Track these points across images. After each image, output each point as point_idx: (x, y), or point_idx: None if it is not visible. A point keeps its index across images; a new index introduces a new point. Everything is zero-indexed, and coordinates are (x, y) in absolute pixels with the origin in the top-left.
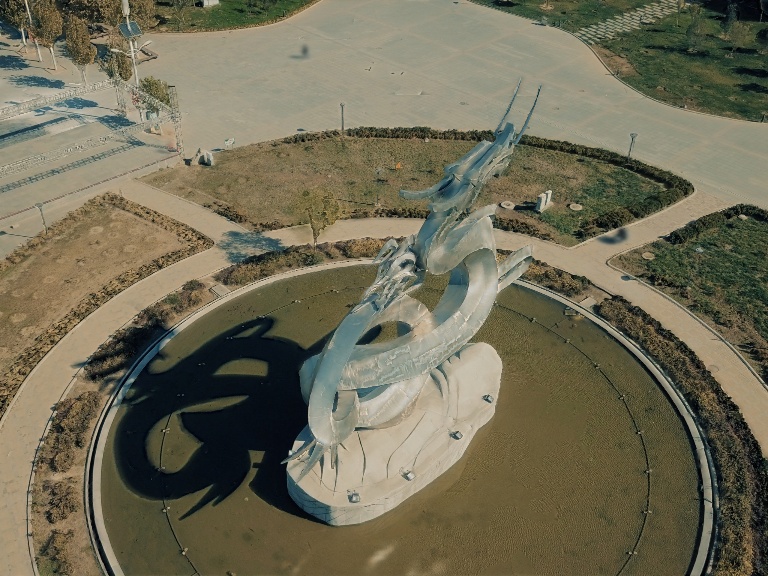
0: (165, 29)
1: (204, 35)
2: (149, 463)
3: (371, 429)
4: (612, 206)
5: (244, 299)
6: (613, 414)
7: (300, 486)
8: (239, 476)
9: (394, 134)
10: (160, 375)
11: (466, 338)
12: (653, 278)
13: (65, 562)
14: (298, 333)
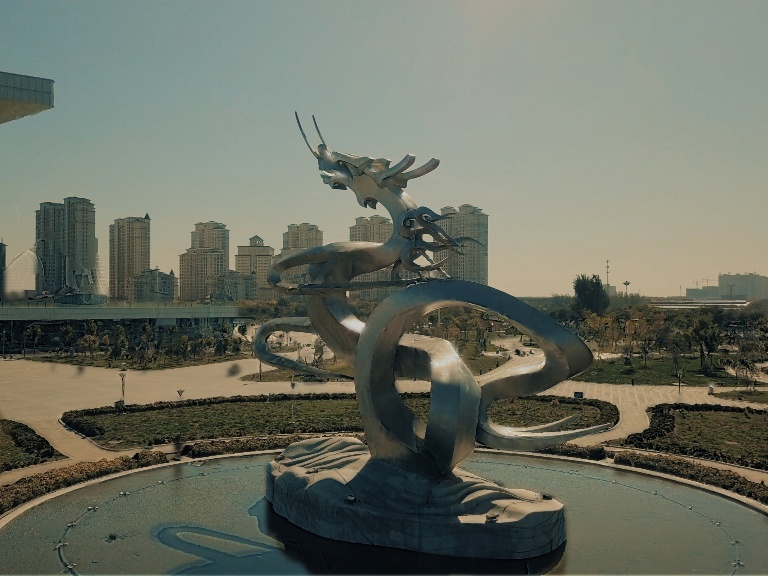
0: None
1: None
2: None
3: None
4: (2, 443)
5: None
6: None
7: (547, 510)
8: None
9: None
10: None
11: None
12: (159, 441)
13: None
14: (164, 568)
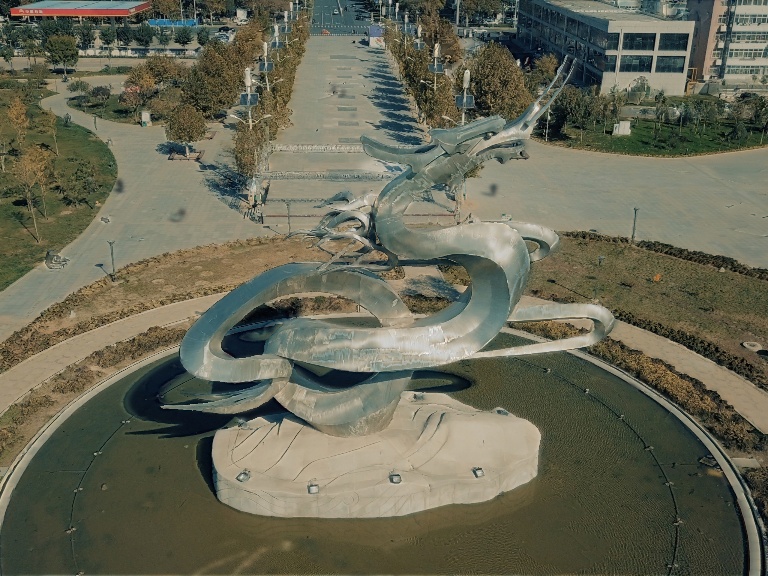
0: (560, 143)
1: (590, 153)
2: (159, 389)
3: (317, 429)
4: None
5: (376, 321)
6: (639, 575)
7: (213, 444)
8: (204, 429)
9: (688, 255)
10: (244, 342)
11: (436, 360)
12: None
13: (24, 414)
14: None
